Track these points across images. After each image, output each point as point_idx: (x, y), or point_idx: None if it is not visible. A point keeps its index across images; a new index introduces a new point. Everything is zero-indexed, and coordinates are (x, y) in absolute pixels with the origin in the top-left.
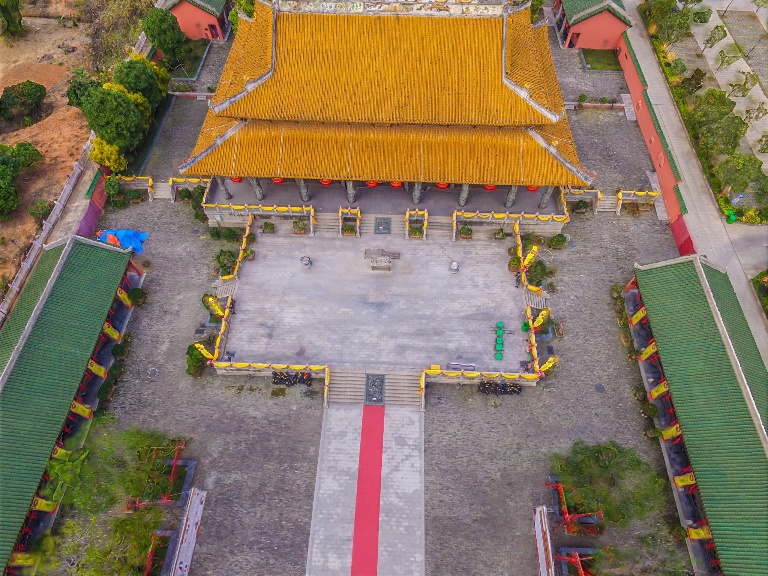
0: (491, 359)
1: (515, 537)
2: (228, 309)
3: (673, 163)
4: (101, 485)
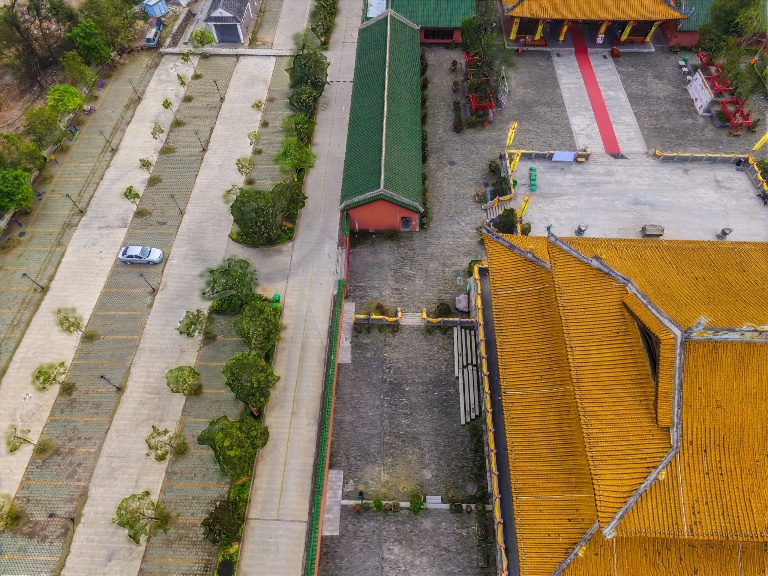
0: (538, 168)
1: (513, 101)
2: (767, 190)
3: (336, 334)
4: (766, 118)
